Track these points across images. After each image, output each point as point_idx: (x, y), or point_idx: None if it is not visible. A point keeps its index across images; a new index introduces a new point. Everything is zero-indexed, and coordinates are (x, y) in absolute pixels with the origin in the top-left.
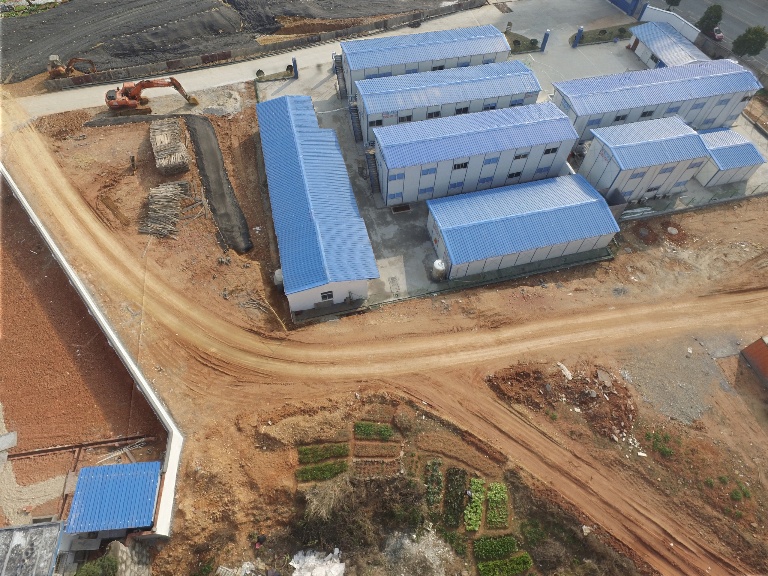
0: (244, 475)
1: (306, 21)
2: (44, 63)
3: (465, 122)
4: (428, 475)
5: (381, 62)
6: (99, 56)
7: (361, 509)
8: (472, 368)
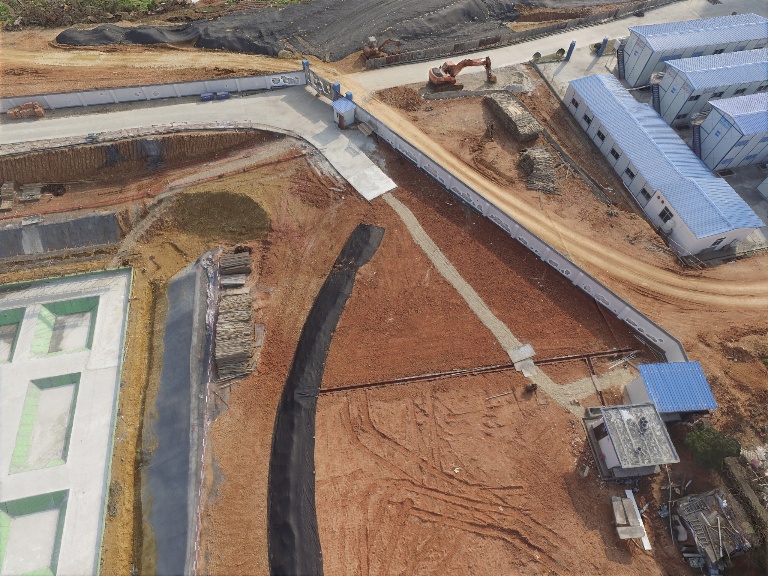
0: (731, 380)
1: (541, 10)
2: (350, 44)
3: None
4: None
5: (677, 45)
6: None
7: None
8: None
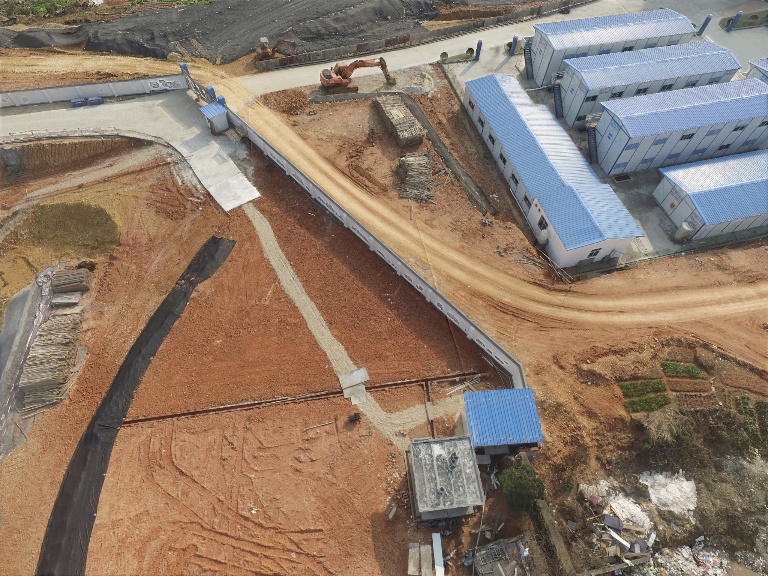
0: (580, 406)
1: (461, 8)
2: (245, 46)
3: (685, 96)
4: (740, 408)
5: (580, 43)
6: (291, 39)
7: (694, 435)
8: (746, 317)
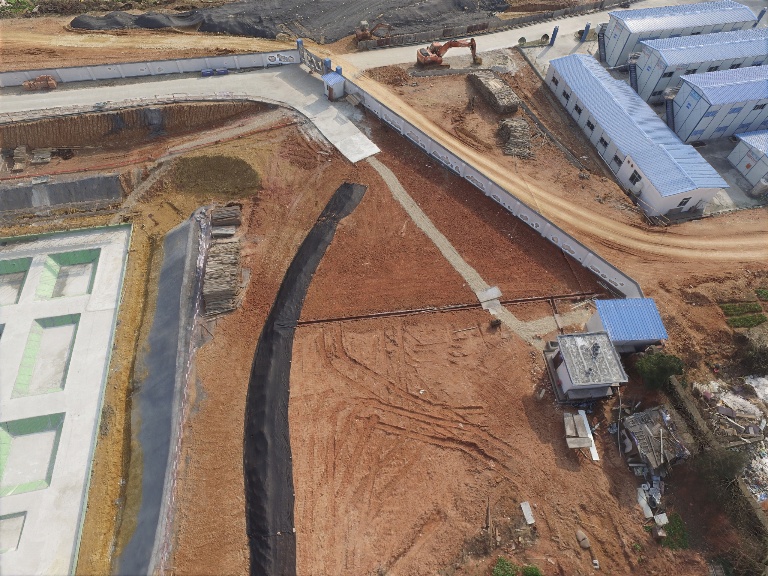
0: (688, 321)
1: (529, 2)
2: (344, 29)
3: (756, 72)
4: None
5: (654, 27)
6: None
7: None
8: None
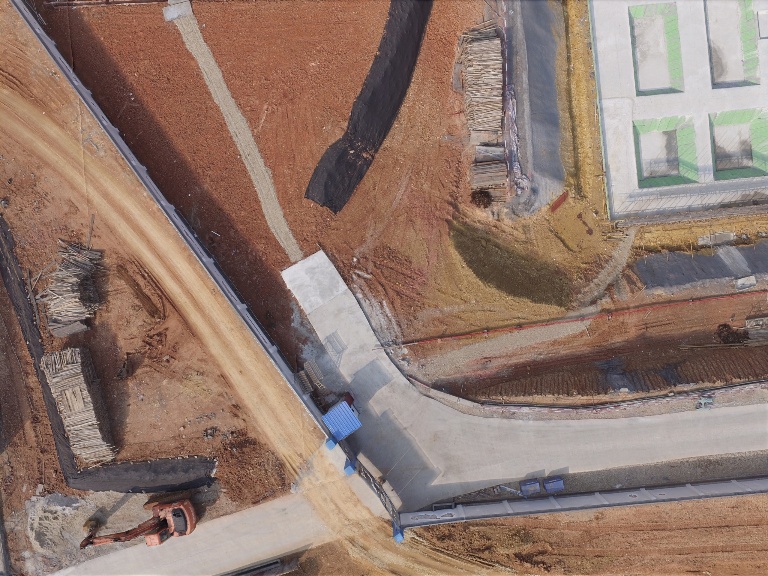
0: None
1: None
2: None
3: None
4: None
5: None
6: None
7: None
8: None
